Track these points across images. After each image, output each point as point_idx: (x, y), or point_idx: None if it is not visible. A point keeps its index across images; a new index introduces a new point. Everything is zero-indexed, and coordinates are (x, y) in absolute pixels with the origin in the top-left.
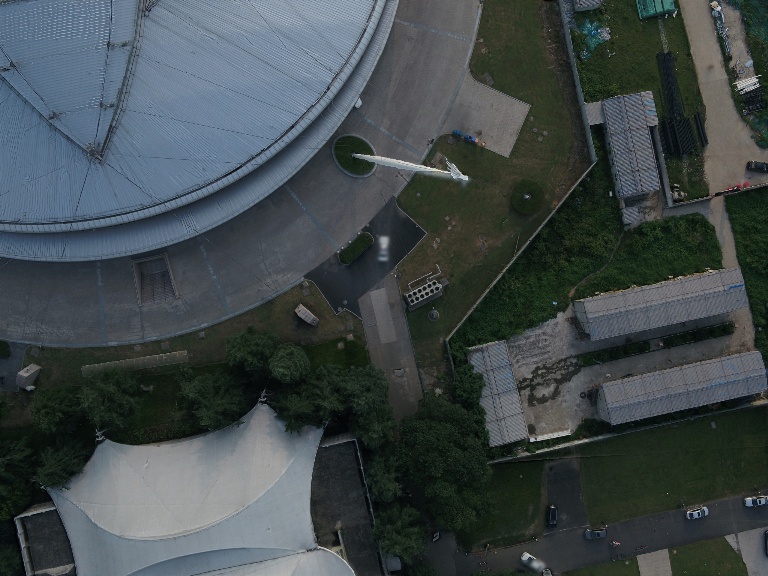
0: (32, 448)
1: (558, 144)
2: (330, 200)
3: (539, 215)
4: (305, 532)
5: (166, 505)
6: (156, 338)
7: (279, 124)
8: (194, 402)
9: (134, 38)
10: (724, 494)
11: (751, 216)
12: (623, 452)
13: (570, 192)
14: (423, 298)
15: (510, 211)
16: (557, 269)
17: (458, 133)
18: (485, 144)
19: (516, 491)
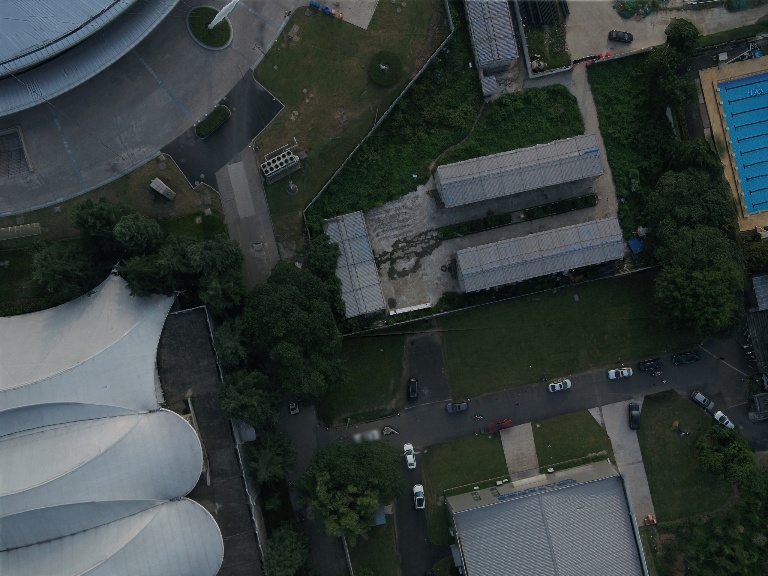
0: None
1: (417, 15)
2: (186, 73)
3: (398, 87)
4: (147, 393)
5: (5, 365)
6: (11, 213)
7: None
8: None
9: None
10: (588, 367)
11: (613, 87)
12: (485, 325)
13: (427, 62)
14: (277, 168)
15: (368, 83)
16: (416, 141)
17: (314, 4)
18: (342, 15)
19: (377, 365)
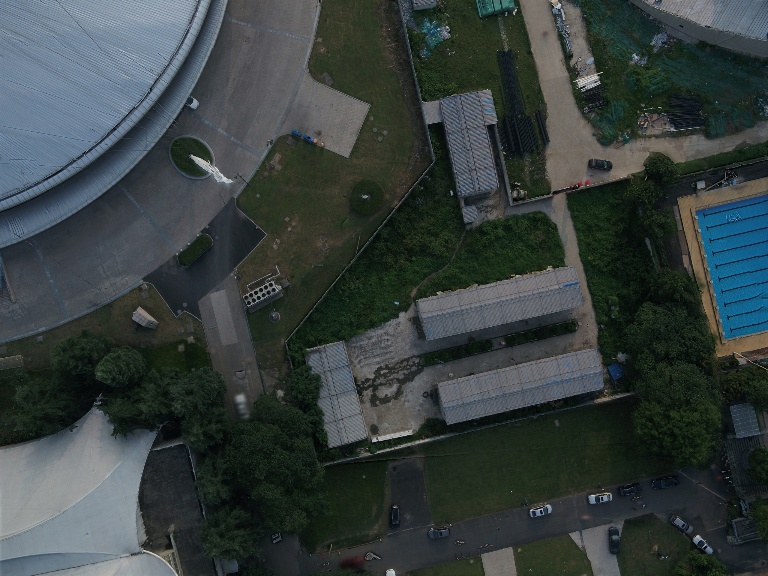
0: None
1: (398, 143)
2: (168, 202)
3: (380, 215)
4: (129, 536)
5: None
6: None
7: (99, 127)
8: None
9: None
10: (568, 492)
11: (593, 214)
12: (466, 451)
13: (408, 192)
14: (260, 300)
15: (350, 211)
16: (398, 269)
17: (296, 133)
18: (324, 144)
19: (359, 491)
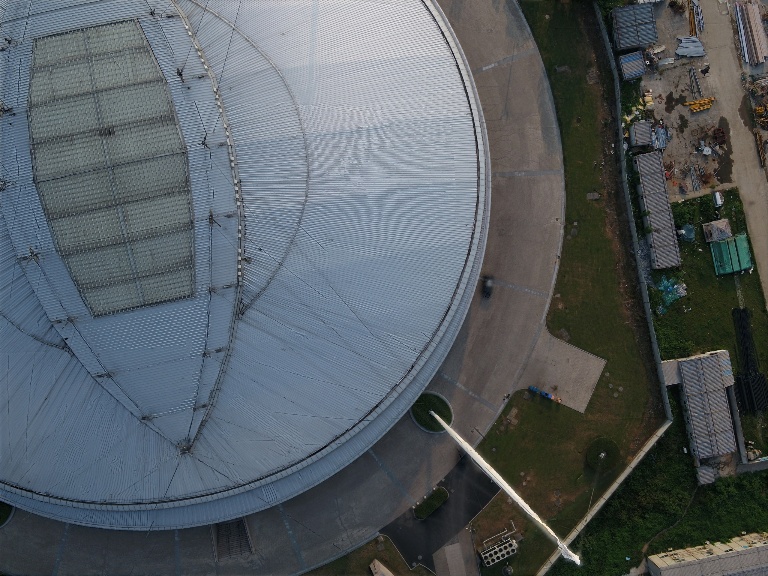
0: None
1: (633, 400)
2: (406, 455)
3: (613, 471)
4: None
5: None
6: None
7: (364, 406)
8: None
9: None
10: None
11: None
12: None
13: (646, 452)
14: (499, 560)
15: (585, 467)
16: (631, 526)
17: (534, 390)
18: (561, 401)
19: None
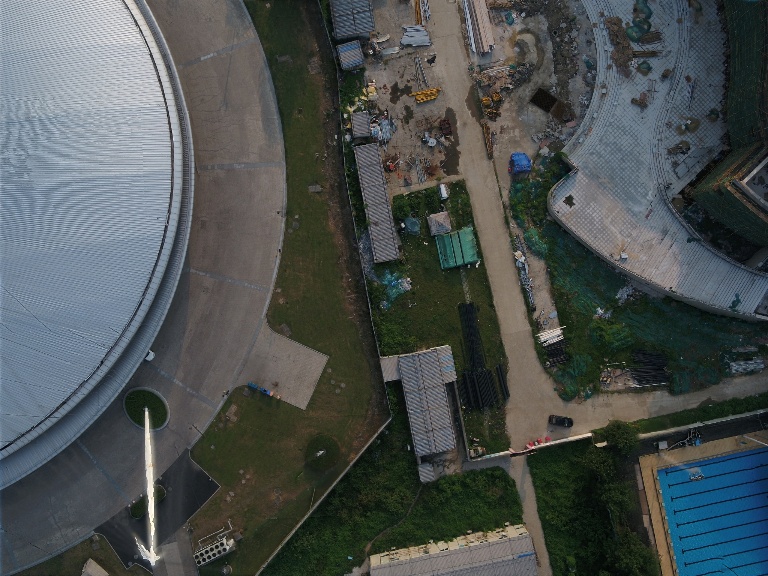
0: None
1: (356, 396)
2: (122, 453)
3: (336, 468)
4: None
5: None
6: None
7: (48, 402)
8: None
9: None
10: None
11: (552, 471)
12: None
13: (364, 449)
14: (210, 559)
15: (305, 465)
16: (352, 524)
17: (252, 386)
18: (280, 397)
19: None
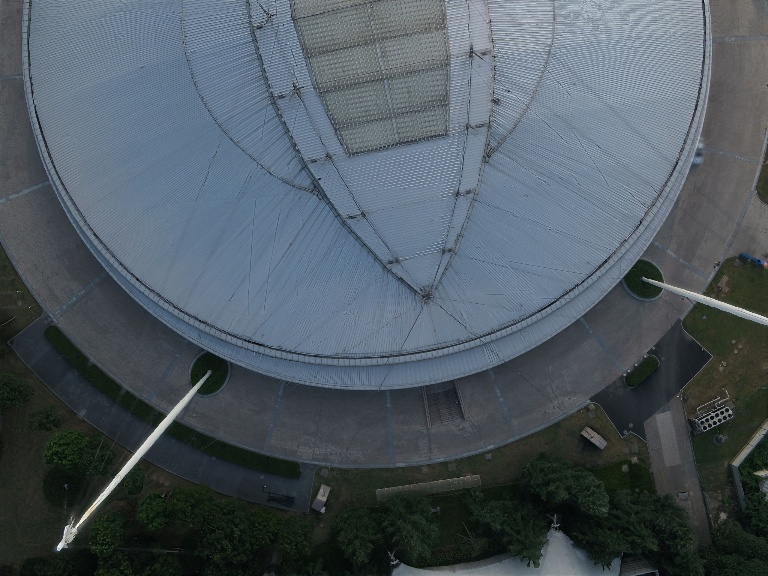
0: (326, 570)
1: None
2: (617, 323)
3: None
4: None
5: None
6: (443, 459)
7: (595, 260)
8: (490, 528)
9: (476, 185)
10: None
11: None
12: None
13: None
14: (715, 425)
15: None
16: None
17: (747, 257)
18: None
19: None
